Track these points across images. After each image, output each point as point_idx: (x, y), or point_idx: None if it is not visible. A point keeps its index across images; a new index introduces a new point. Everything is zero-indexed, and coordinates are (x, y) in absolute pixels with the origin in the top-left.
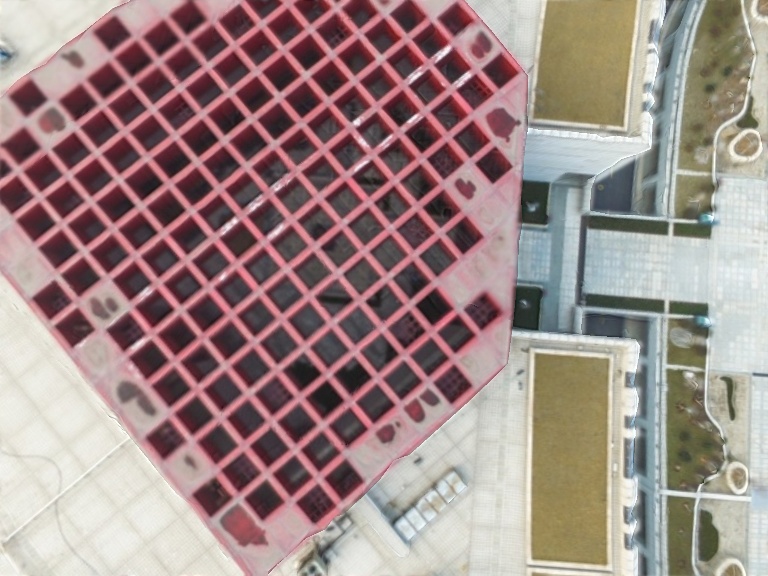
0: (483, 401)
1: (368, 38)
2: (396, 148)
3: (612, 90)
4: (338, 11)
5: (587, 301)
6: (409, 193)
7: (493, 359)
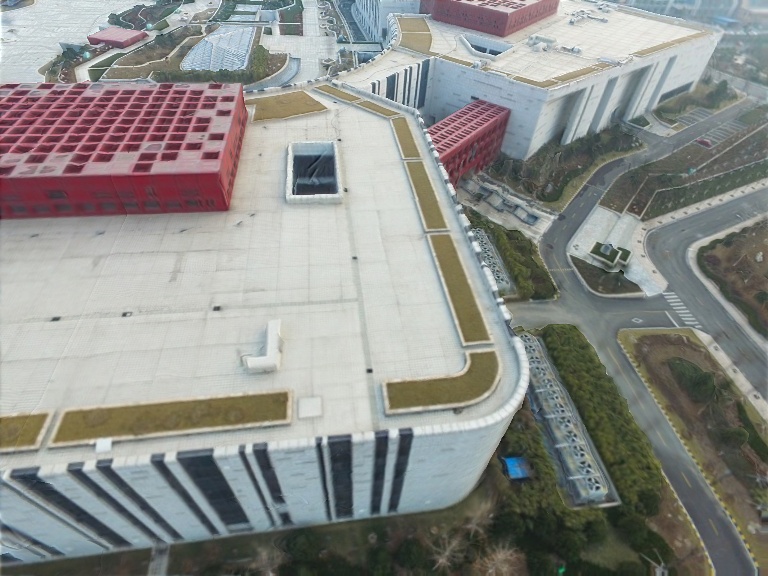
0: None
1: None
2: None
3: (403, 20)
4: (487, 0)
5: None
6: None
7: None
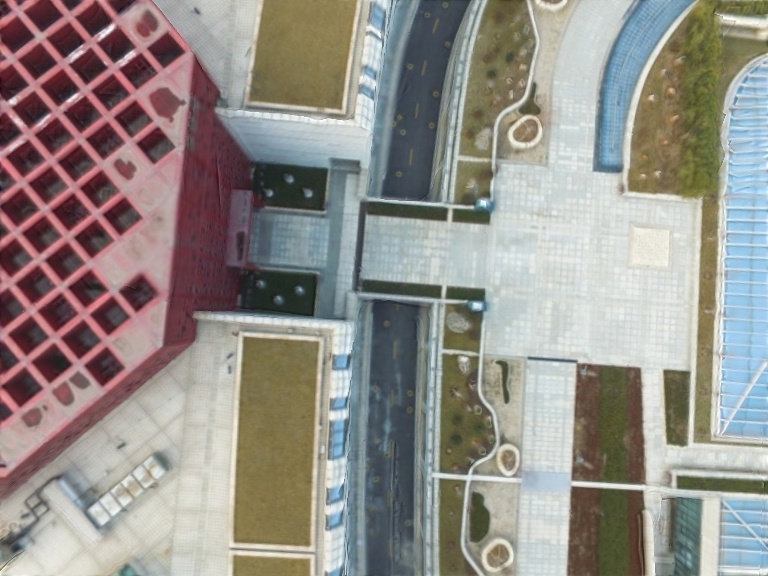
0: (191, 385)
1: (28, 15)
2: (54, 128)
3: (331, 73)
4: None
5: (363, 287)
6: (68, 174)
7: (148, 341)
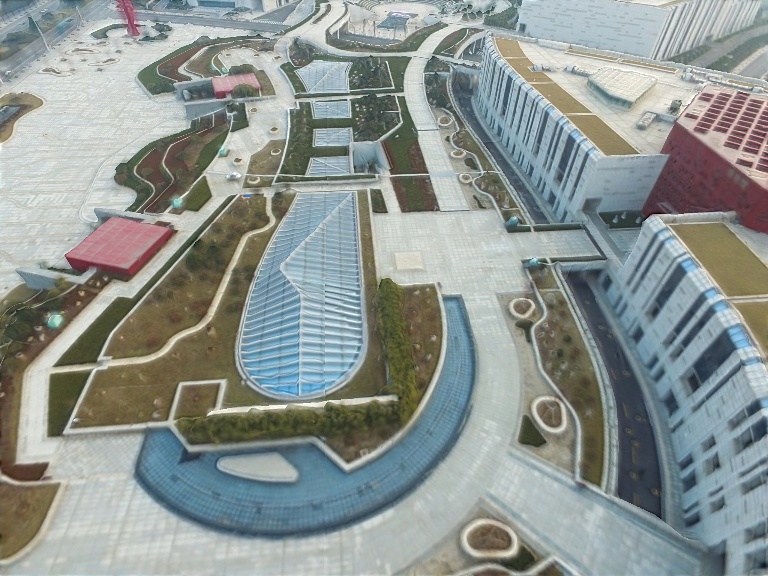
0: None
1: None
2: None
3: None
4: None
5: (580, 226)
6: None
7: None
